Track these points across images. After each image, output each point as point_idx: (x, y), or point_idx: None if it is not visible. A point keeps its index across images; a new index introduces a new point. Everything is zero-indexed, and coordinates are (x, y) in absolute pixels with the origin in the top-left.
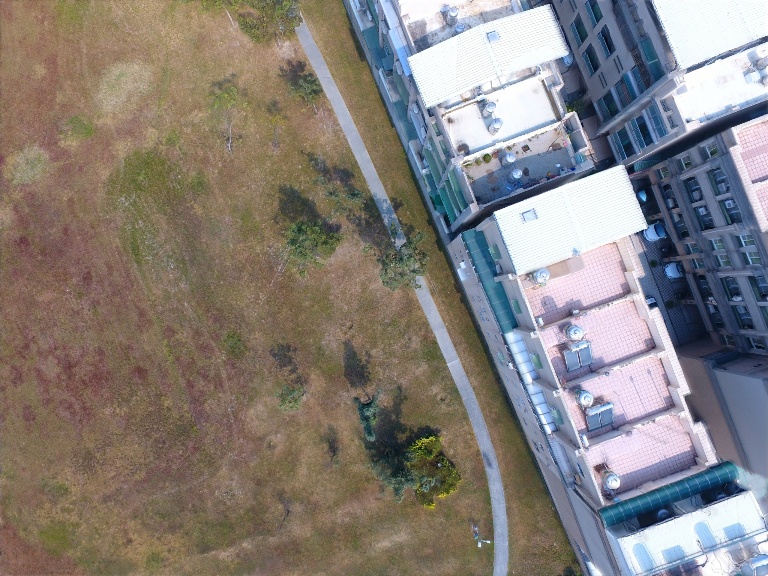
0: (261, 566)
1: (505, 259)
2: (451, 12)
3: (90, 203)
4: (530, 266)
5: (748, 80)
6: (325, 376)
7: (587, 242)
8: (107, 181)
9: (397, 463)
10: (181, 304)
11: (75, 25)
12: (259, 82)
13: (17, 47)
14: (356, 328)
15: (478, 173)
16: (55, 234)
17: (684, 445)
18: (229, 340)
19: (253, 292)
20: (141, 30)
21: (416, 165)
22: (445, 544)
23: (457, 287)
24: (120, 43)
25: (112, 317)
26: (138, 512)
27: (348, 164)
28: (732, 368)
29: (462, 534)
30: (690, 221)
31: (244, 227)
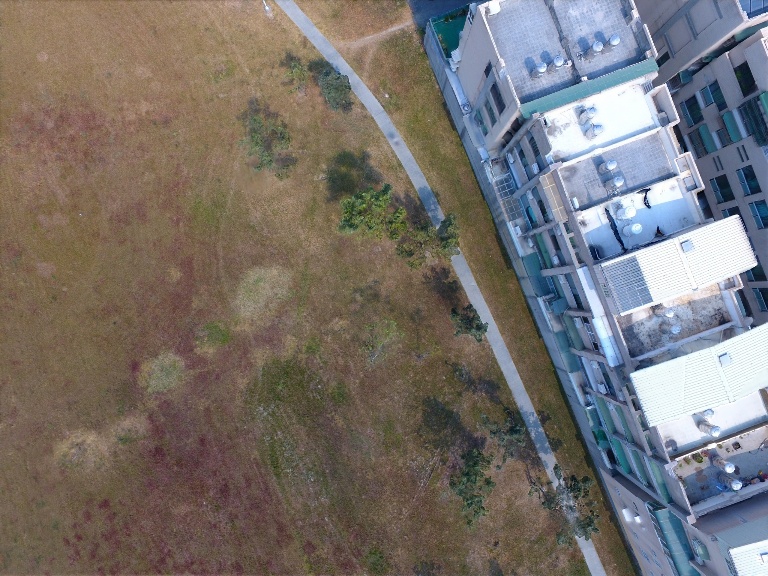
0: None
1: (721, 571)
2: (667, 314)
3: (227, 413)
4: None
5: None
6: None
7: None
8: (245, 390)
9: None
10: (321, 519)
11: (211, 227)
12: (402, 289)
13: (151, 249)
14: (502, 546)
15: (686, 471)
16: (191, 444)
17: None
18: (371, 557)
19: (396, 507)
20: (280, 233)
21: (573, 391)
22: None
23: (606, 505)
24: (258, 247)
25: (250, 531)
26: None
27: (494, 375)
28: None
29: None
30: None
31: (386, 440)
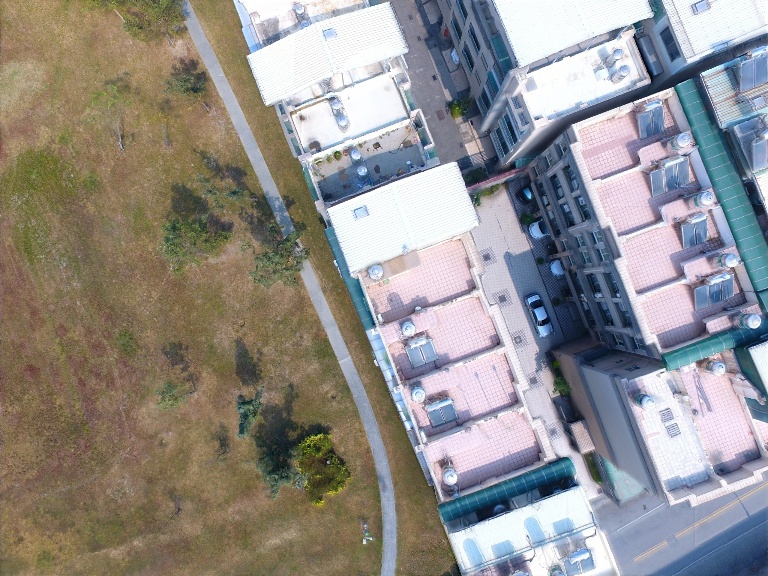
0: (151, 564)
1: None
2: (297, 10)
3: None
4: (362, 263)
5: (598, 77)
6: (217, 374)
7: (417, 239)
8: None
9: (282, 460)
10: (73, 303)
11: None
12: (152, 81)
13: None
14: (248, 326)
15: (329, 170)
16: None
17: (528, 441)
18: (121, 338)
19: (145, 290)
20: (34, 29)
21: None
22: (334, 541)
23: None
24: (13, 42)
25: (4, 316)
26: (30, 510)
27: (240, 162)
28: (599, 364)
29: (351, 531)
30: (559, 218)
31: (136, 225)
